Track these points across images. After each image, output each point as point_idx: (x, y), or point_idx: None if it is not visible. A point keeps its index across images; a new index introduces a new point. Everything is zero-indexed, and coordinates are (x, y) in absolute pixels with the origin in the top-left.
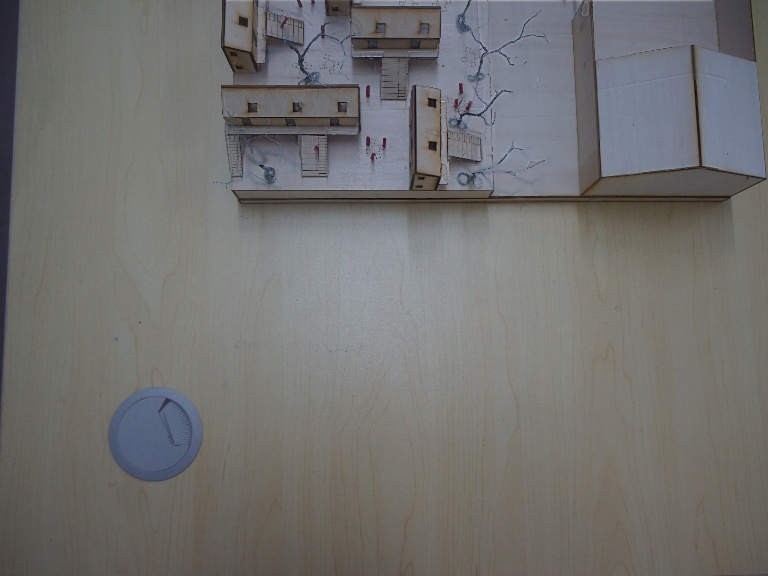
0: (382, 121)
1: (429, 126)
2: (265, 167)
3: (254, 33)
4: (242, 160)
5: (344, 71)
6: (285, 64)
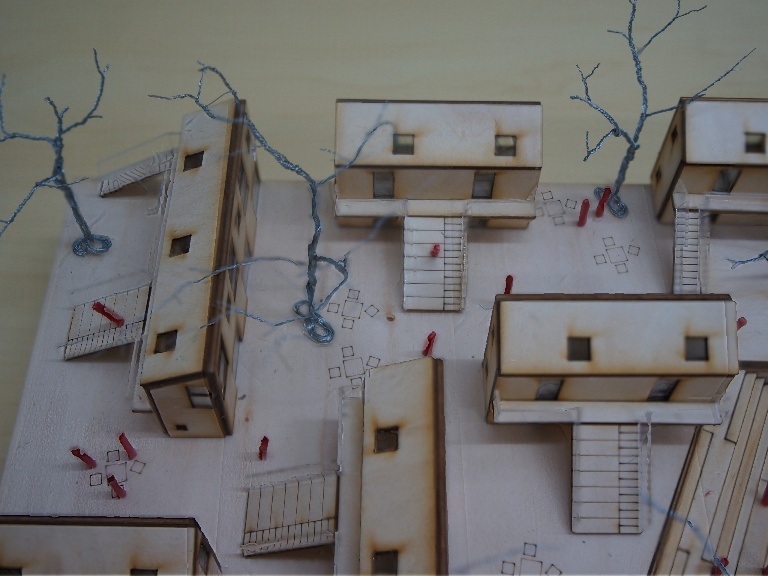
0: (190, 491)
1: (68, 569)
2: (78, 209)
3: (395, 182)
4: (136, 194)
5: (335, 400)
6: (357, 275)
